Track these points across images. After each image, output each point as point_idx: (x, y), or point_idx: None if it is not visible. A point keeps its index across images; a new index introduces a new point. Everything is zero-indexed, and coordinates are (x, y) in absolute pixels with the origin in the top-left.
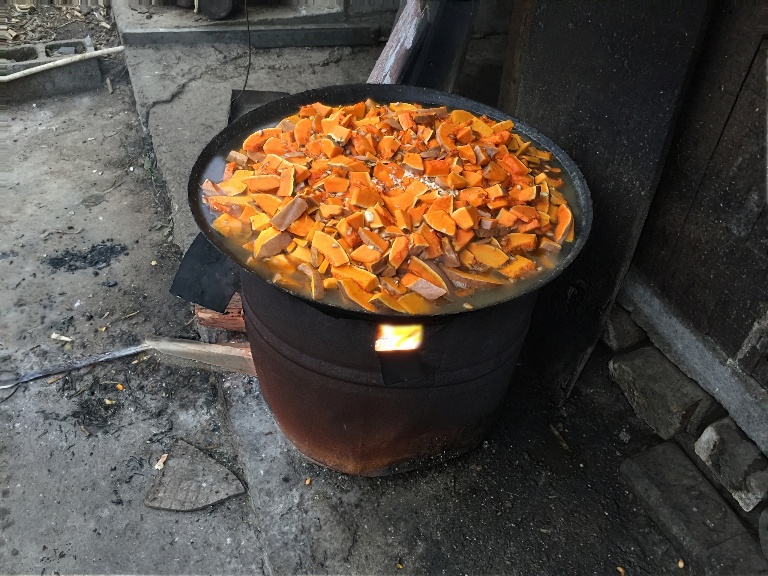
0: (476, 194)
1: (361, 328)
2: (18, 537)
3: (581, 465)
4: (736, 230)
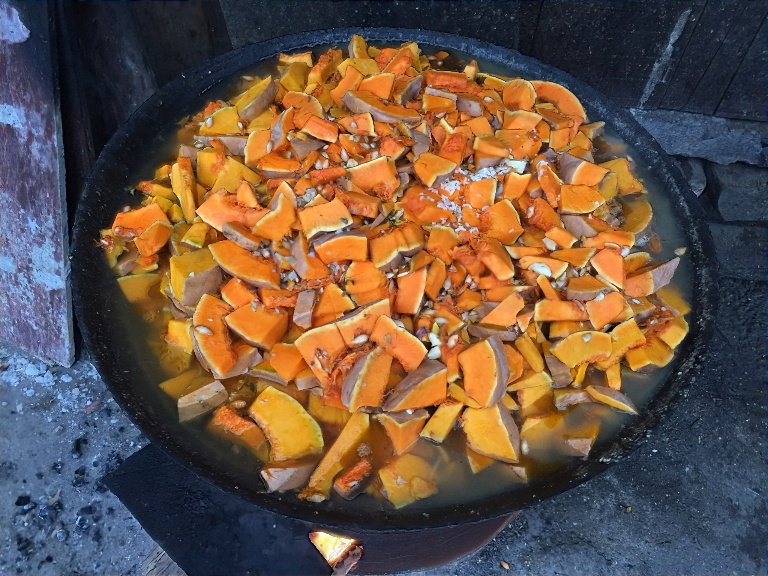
0: (528, 140)
1: None
2: None
3: None
4: None
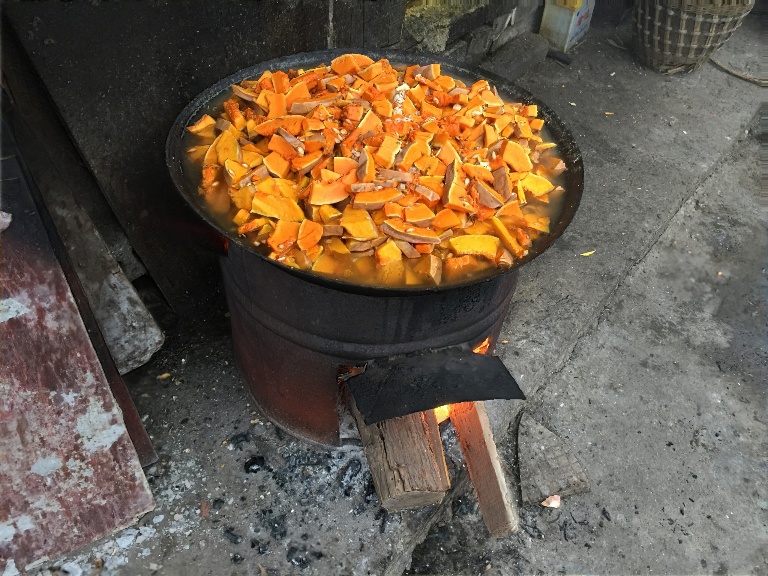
0: (392, 75)
1: None
2: (696, 574)
3: None
4: (293, 5)
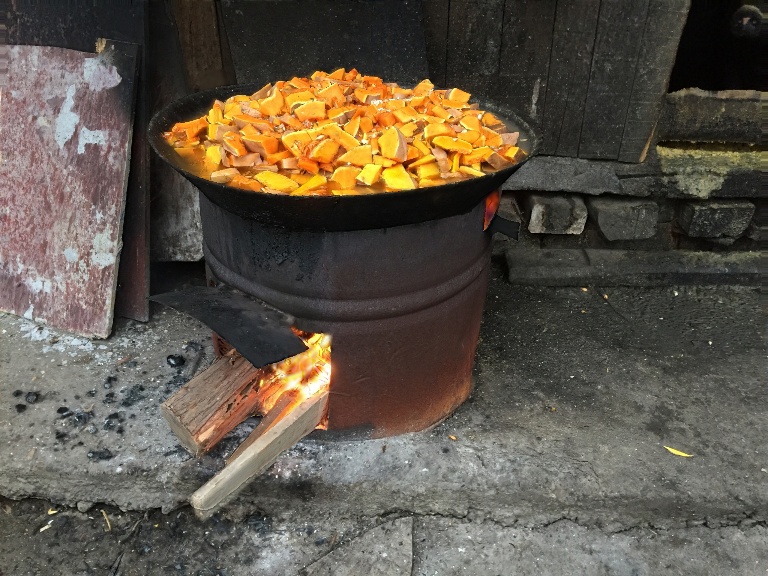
0: (425, 91)
1: (479, 212)
2: None
3: (497, 297)
4: (488, 72)
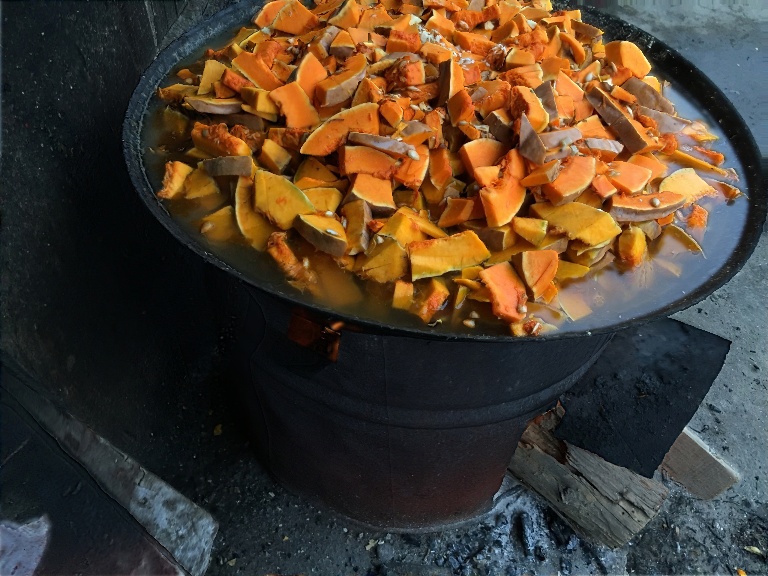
0: (382, 9)
1: None
2: None
3: None
4: None
